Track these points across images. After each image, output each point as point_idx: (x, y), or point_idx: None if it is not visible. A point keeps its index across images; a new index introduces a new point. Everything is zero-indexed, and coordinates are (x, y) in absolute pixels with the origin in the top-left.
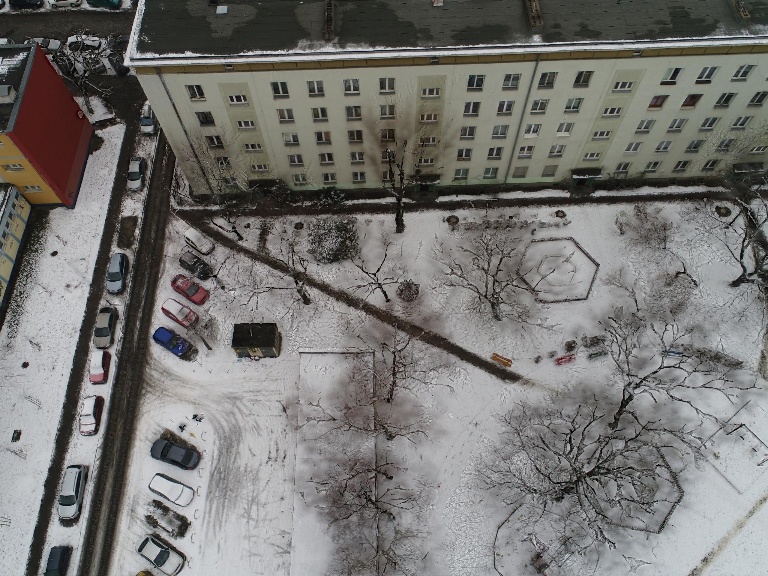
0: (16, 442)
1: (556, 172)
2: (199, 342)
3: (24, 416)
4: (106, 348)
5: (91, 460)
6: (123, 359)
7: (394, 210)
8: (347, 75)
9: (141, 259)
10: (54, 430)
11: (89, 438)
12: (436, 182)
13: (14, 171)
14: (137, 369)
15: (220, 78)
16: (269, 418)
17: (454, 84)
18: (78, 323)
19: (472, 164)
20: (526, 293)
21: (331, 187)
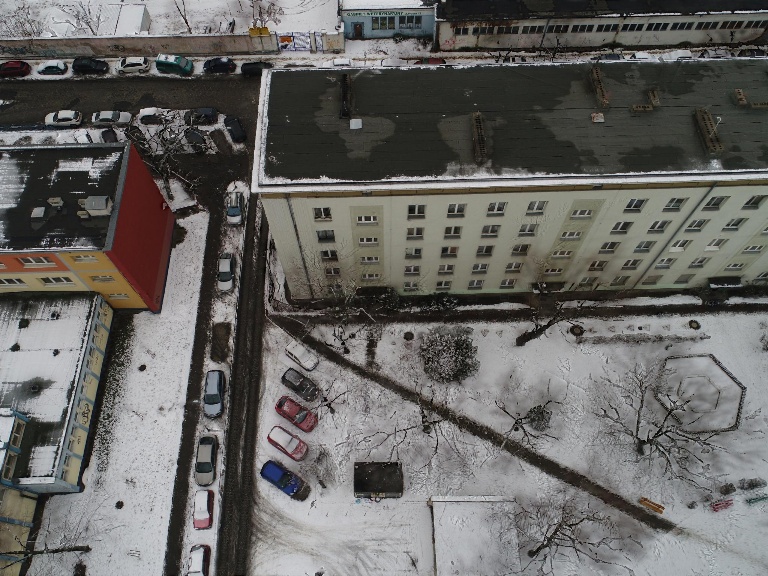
0: None
1: (691, 280)
2: (313, 481)
3: (123, 569)
4: (208, 485)
5: None
6: (227, 497)
7: (511, 318)
8: (496, 199)
9: (238, 374)
10: None
11: None
12: (561, 291)
13: (103, 282)
14: (244, 510)
15: (354, 201)
16: (397, 573)
17: (612, 206)
18: (175, 453)
19: (603, 273)
20: (668, 421)
21: (443, 293)
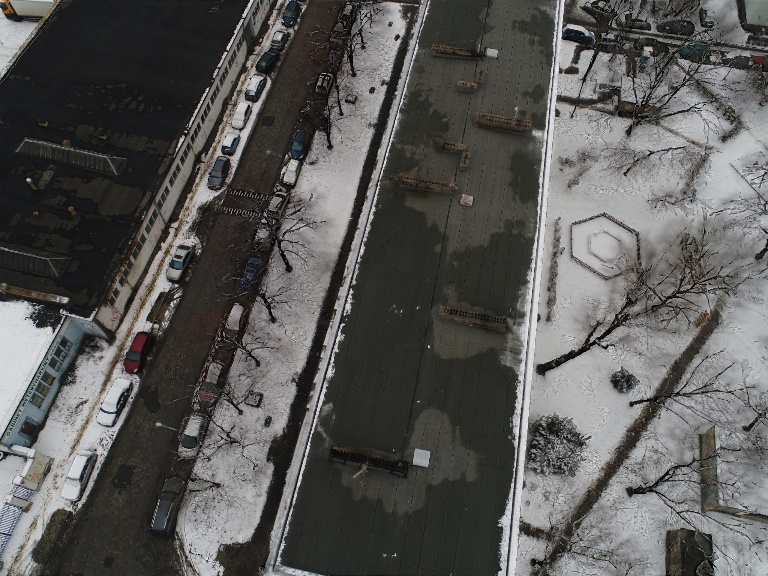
0: None
1: None
2: None
3: None
4: None
5: None
6: None
7: None
8: None
9: None
10: None
11: None
12: None
13: None
14: None
15: None
16: None
17: None
18: None
19: None
20: None
21: None
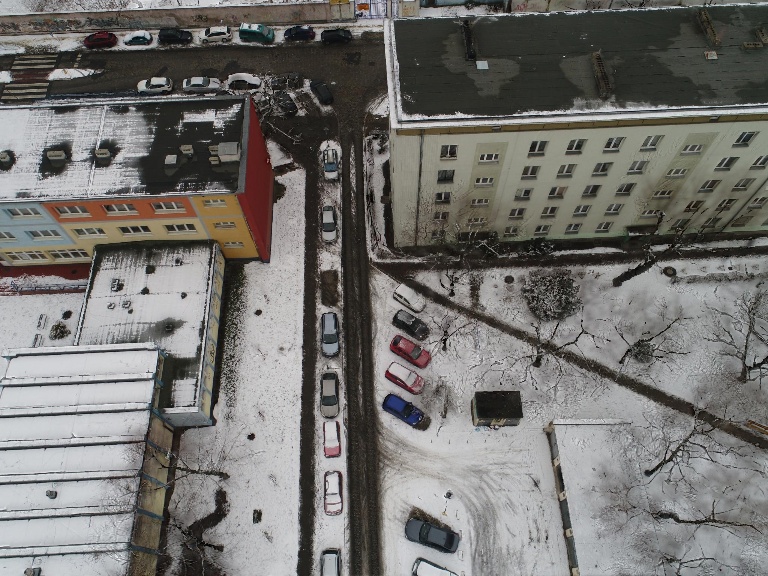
0: (258, 523)
1: None
2: (434, 411)
3: (261, 494)
4: (334, 417)
5: (341, 542)
6: (352, 429)
7: (606, 261)
8: (616, 133)
9: (349, 317)
10: (296, 509)
11: (334, 518)
12: (655, 233)
13: (224, 228)
14: (369, 440)
15: (483, 138)
16: (521, 494)
17: (723, 140)
18: (298, 389)
19: (697, 215)
20: (765, 352)
21: (540, 238)
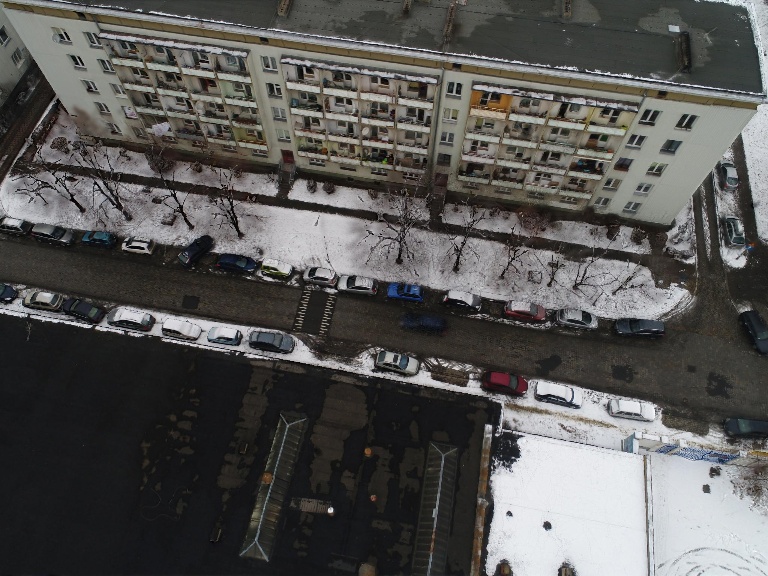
0: None
1: None
2: None
3: None
4: None
5: None
6: None
7: None
8: None
9: None
10: None
11: None
12: None
13: None
14: None
15: None
16: None
17: None
18: None
19: None
20: None
21: None
